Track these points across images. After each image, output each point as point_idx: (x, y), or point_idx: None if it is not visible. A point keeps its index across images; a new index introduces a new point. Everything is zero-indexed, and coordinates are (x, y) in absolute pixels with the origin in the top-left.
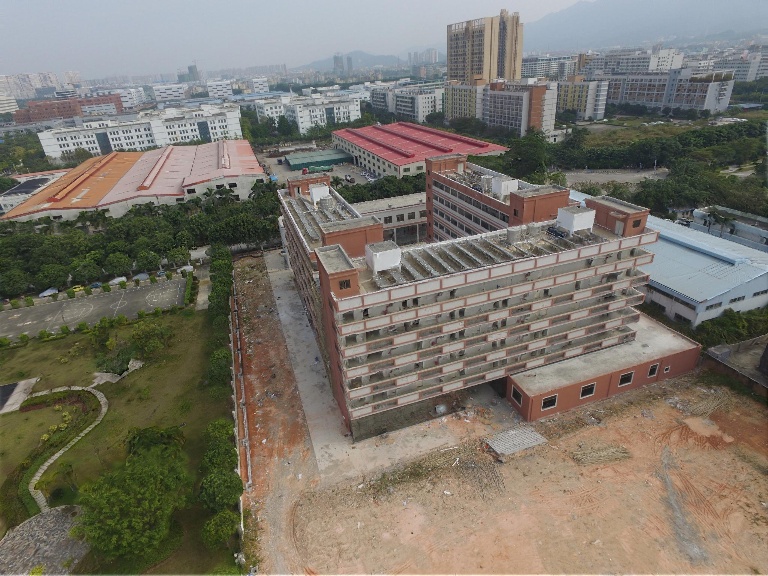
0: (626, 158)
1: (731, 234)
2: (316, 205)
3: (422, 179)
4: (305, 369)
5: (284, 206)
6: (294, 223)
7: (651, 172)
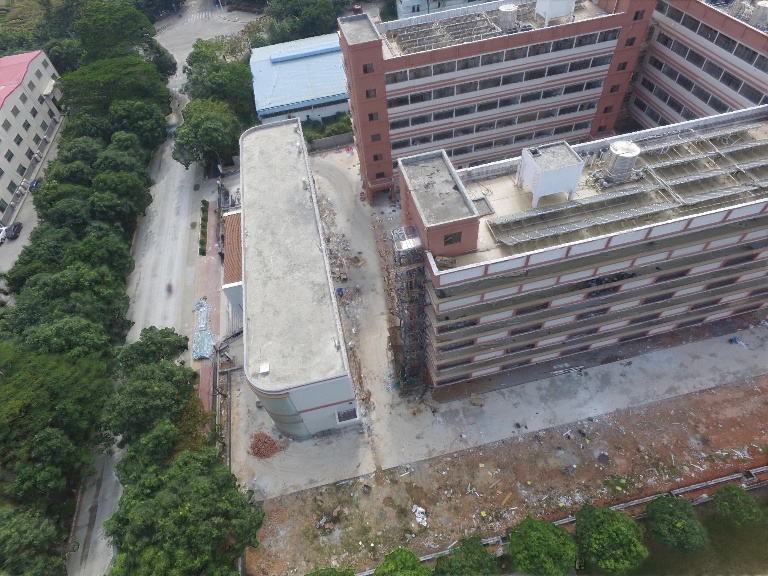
0: (158, 4)
1: (444, 7)
2: (567, 196)
3: (100, 153)
4: (763, 356)
5: (574, 251)
6: (764, 201)
7: (191, 11)
